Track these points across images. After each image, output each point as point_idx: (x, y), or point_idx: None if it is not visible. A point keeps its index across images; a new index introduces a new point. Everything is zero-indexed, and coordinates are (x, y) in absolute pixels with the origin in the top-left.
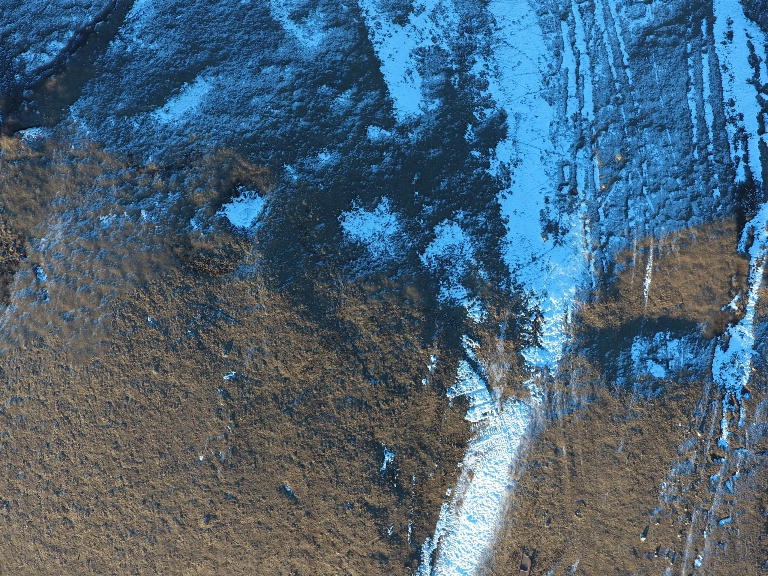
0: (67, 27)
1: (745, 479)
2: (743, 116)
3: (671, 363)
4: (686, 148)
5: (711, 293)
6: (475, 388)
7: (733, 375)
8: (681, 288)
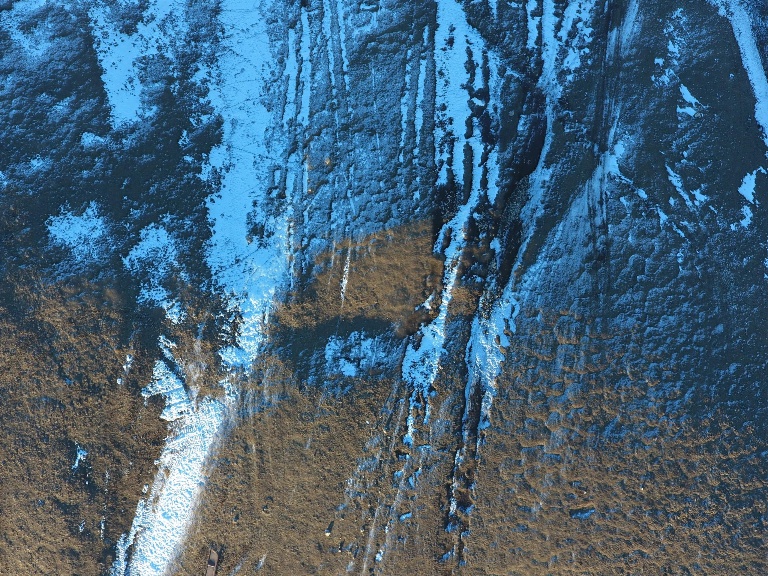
0: None
1: (426, 475)
2: (453, 120)
3: (362, 362)
4: (392, 152)
5: (405, 293)
6: (171, 387)
7: (422, 373)
8: (376, 288)
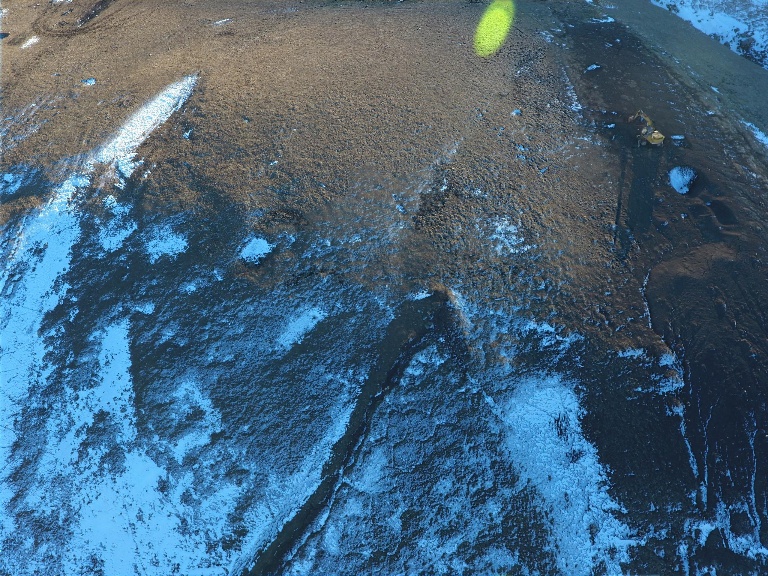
0: (408, 389)
1: None
2: None
3: None
4: None
5: None
6: (126, 166)
7: None
8: None
